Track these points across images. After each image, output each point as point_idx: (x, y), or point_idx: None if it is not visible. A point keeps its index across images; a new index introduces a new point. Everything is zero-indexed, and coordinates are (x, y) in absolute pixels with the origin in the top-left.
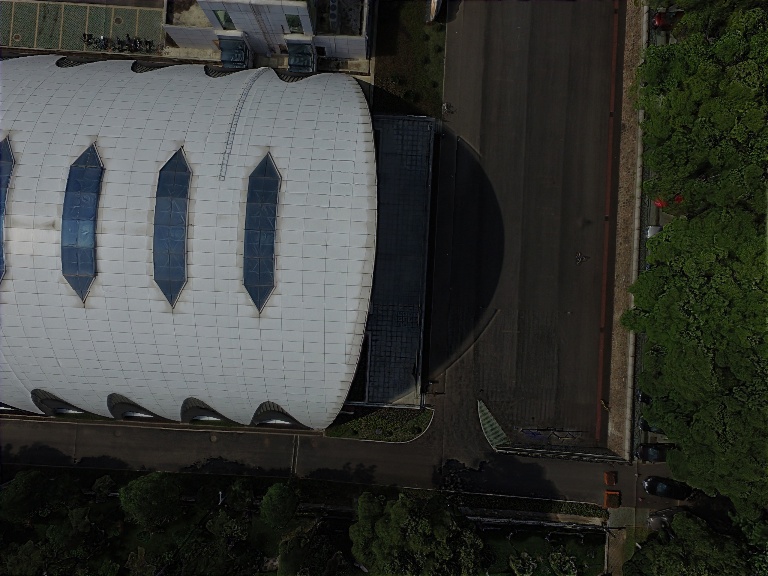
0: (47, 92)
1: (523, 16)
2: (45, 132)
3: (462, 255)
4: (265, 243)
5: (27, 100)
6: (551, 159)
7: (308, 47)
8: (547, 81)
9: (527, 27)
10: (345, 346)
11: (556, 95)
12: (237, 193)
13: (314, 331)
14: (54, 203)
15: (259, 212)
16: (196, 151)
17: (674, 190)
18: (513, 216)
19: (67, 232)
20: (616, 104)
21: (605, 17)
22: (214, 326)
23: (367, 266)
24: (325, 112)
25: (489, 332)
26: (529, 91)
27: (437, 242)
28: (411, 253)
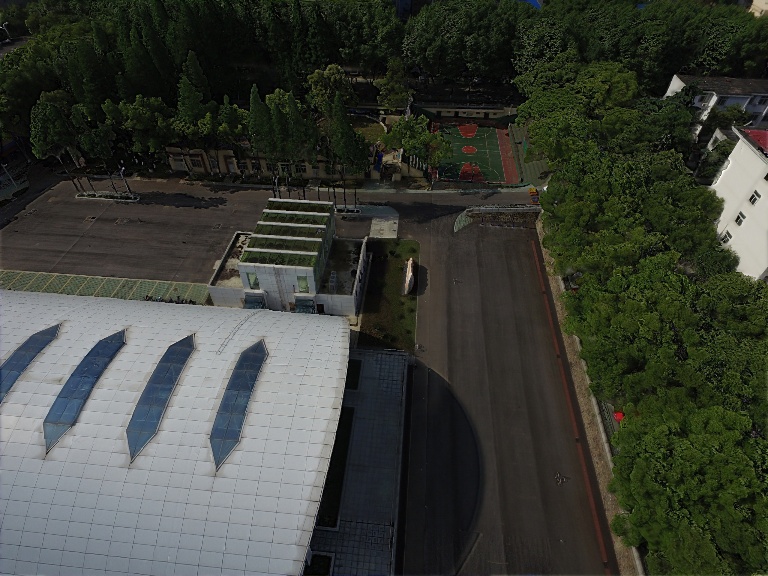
0: (106, 305)
1: (475, 293)
2: (91, 322)
3: (437, 471)
4: (240, 403)
5: (89, 307)
6: (513, 388)
7: (311, 302)
8: (499, 332)
9: (478, 300)
10: (298, 517)
11: (509, 342)
12: (228, 363)
13: (268, 496)
14: (71, 364)
15: (242, 379)
16: (204, 336)
17: (616, 386)
18: (485, 435)
19: (68, 387)
20: (560, 349)
21: (537, 296)
22: (165, 486)
23: (331, 425)
24: (314, 322)
25: (472, 562)
26: (486, 338)
27: (411, 457)
28: (384, 465)
